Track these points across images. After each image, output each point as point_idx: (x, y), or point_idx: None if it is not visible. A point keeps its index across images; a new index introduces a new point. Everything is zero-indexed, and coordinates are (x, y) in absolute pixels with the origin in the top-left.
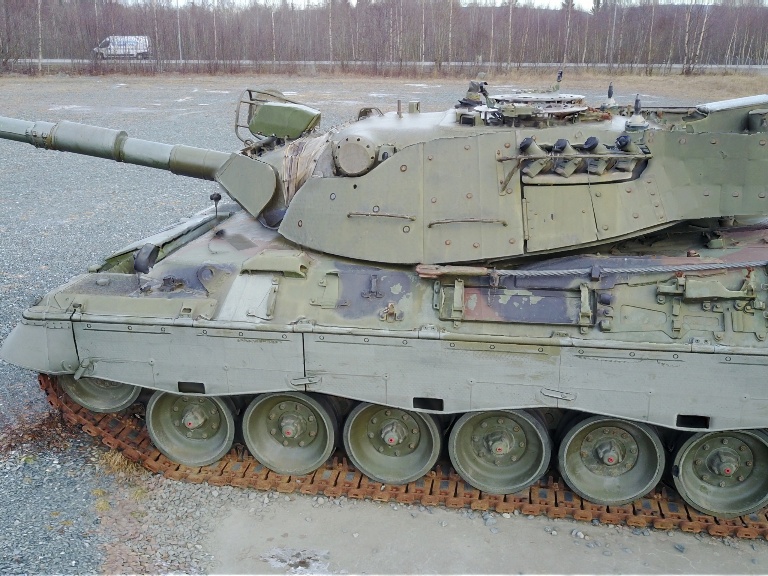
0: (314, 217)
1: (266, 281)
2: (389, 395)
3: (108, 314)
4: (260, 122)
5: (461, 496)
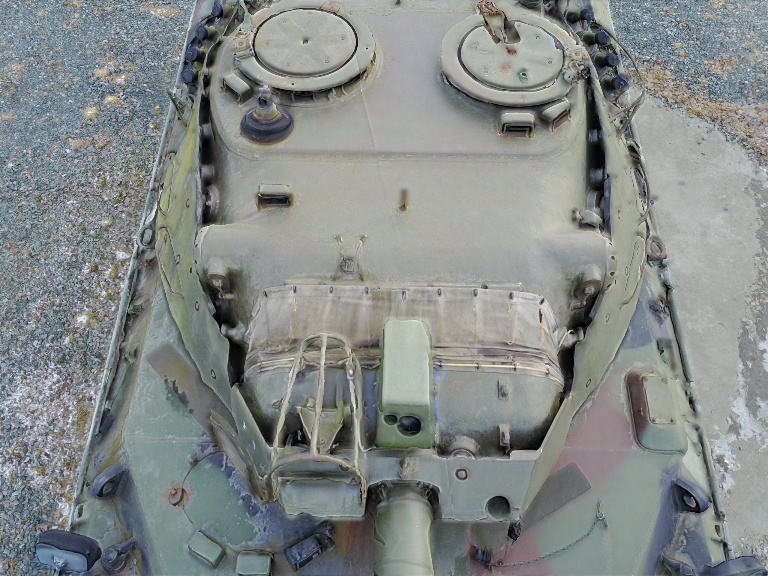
0: None
1: None
2: None
3: None
4: None
5: None
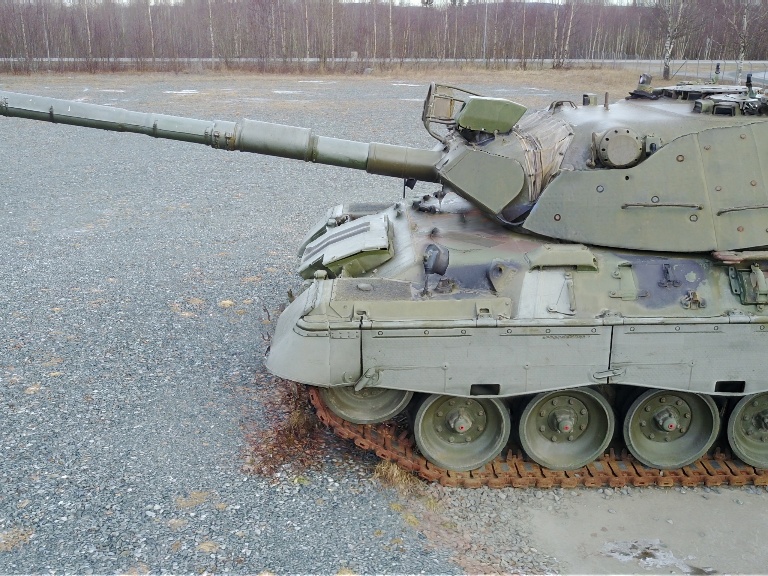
0: (577, 210)
1: (558, 276)
2: (693, 381)
3: (397, 320)
4: (469, 117)
5: (740, 474)
